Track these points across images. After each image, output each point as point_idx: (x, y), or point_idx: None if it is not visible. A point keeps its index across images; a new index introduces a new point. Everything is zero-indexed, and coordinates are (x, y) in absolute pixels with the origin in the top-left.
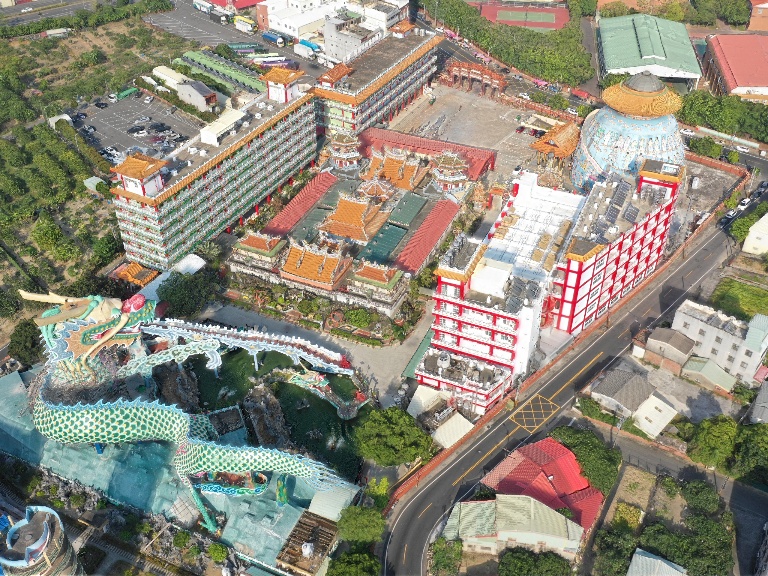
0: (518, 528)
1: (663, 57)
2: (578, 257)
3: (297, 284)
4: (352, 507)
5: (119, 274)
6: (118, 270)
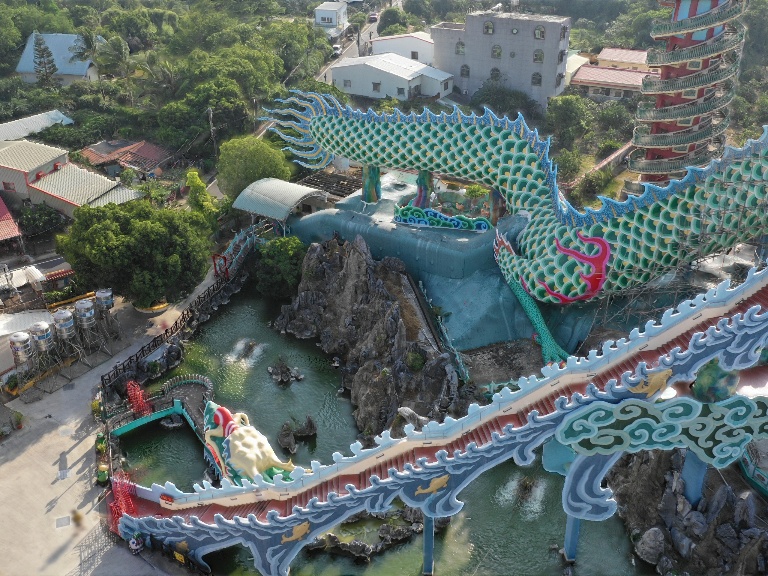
0: (39, 145)
1: None
2: None
3: None
4: (263, 145)
5: None
6: None
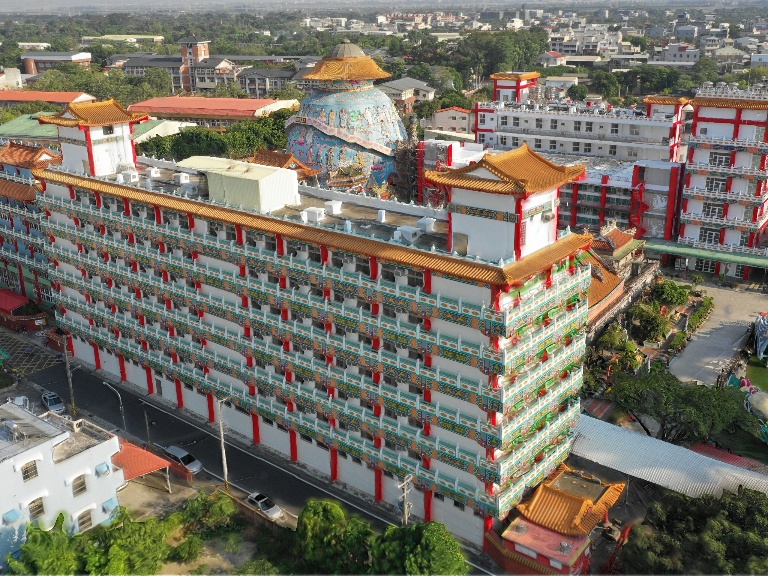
0: None
1: (154, 117)
2: (683, 100)
3: (608, 314)
4: None
5: (579, 530)
6: (542, 545)
